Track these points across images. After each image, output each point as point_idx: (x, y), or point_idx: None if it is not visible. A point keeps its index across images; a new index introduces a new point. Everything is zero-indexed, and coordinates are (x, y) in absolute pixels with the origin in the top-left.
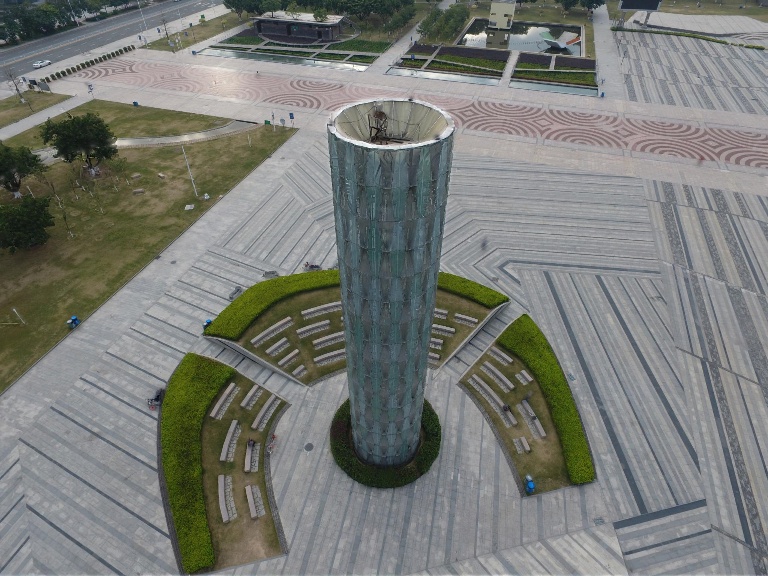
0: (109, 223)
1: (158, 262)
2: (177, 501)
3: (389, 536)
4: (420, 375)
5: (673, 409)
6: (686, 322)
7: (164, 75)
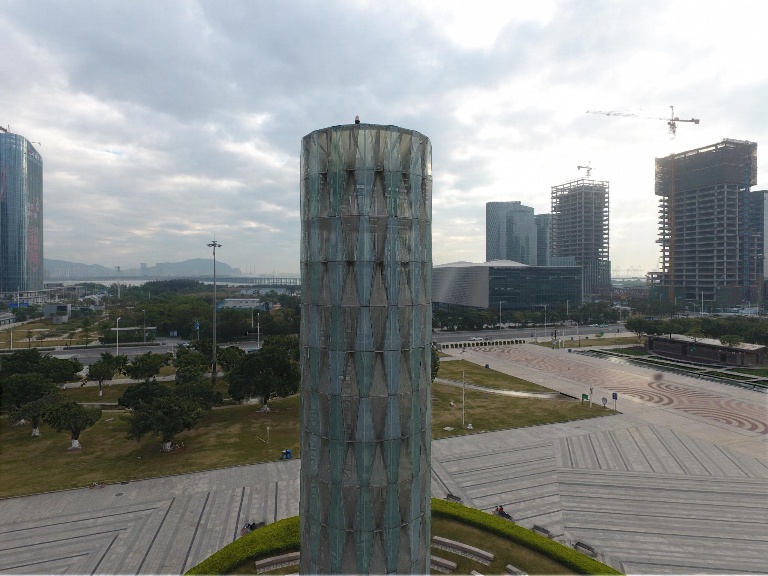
0: None
1: None
2: None
3: None
4: (366, 562)
5: None
6: None
7: (529, 358)
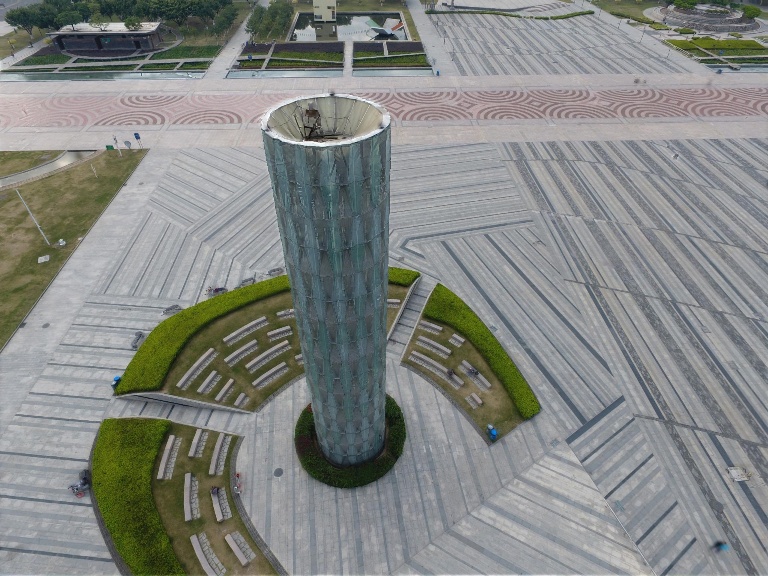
0: None
1: (25, 330)
2: None
3: (387, 527)
4: (383, 363)
5: (578, 331)
6: (564, 257)
7: None
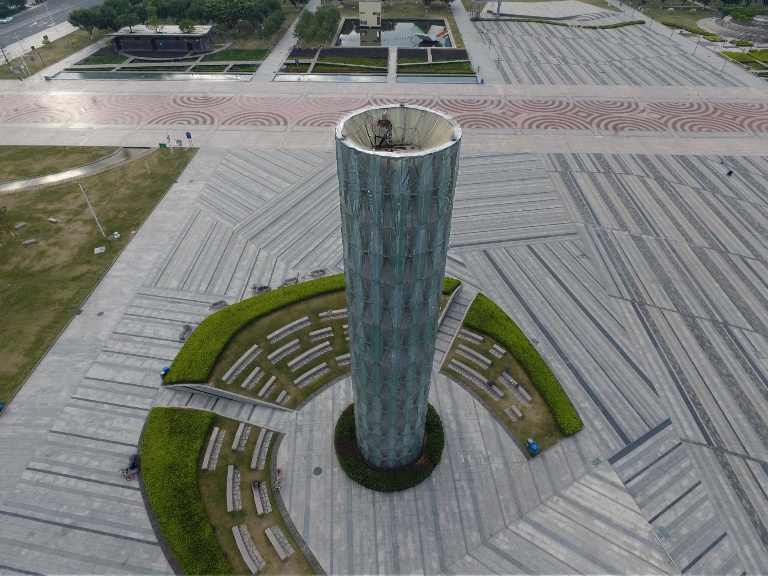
0: (3, 285)
1: (81, 317)
2: (194, 569)
3: (424, 533)
4: (429, 370)
5: (623, 349)
6: (610, 272)
7: (17, 107)
